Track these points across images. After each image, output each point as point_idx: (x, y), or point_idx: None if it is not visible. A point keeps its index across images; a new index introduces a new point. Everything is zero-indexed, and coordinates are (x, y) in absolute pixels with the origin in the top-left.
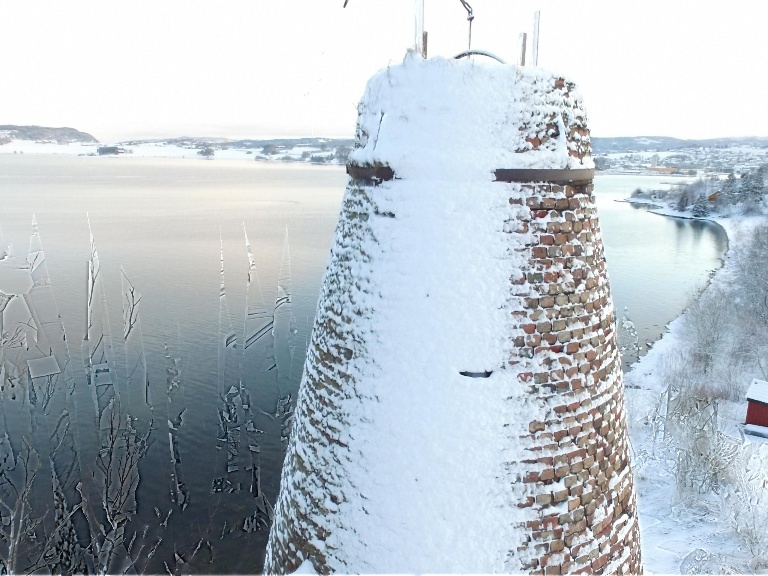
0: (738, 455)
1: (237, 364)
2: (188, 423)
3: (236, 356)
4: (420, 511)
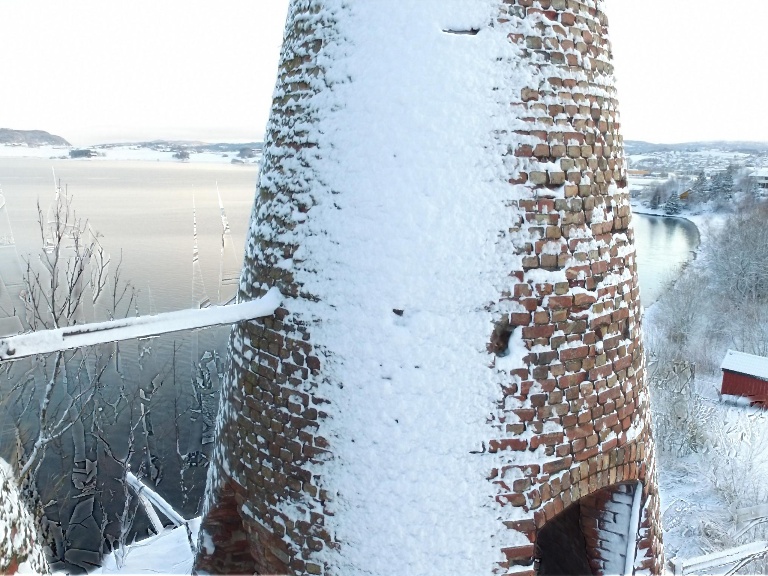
0: (716, 412)
1: (211, 331)
2: (160, 389)
3: None
4: (399, 189)
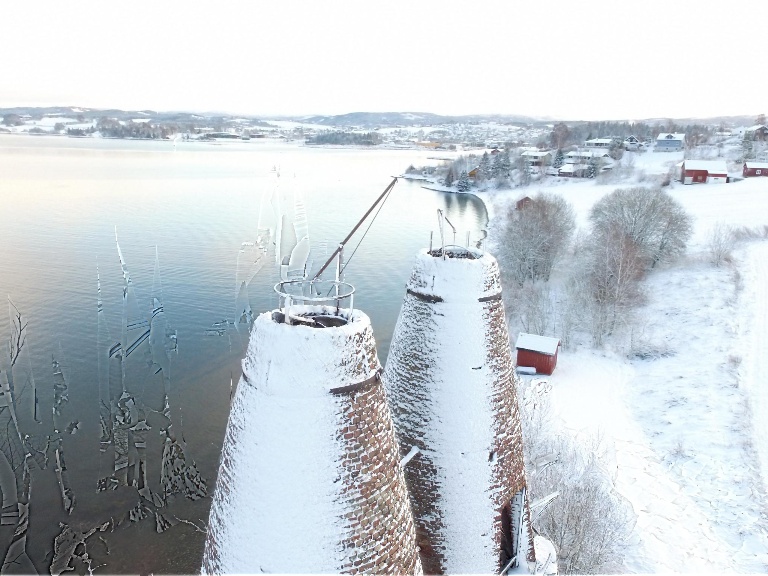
0: (517, 389)
1: (120, 372)
2: (84, 431)
3: (118, 365)
4: (462, 417)
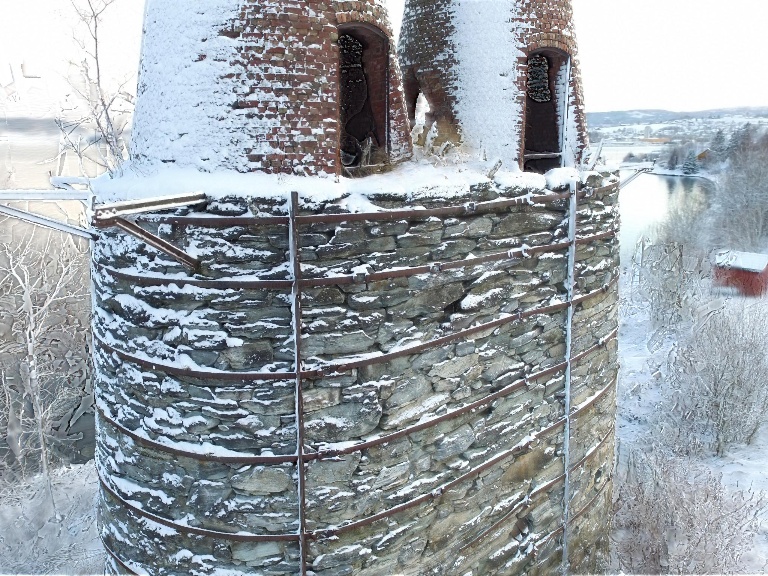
0: None
1: None
2: None
3: None
4: None
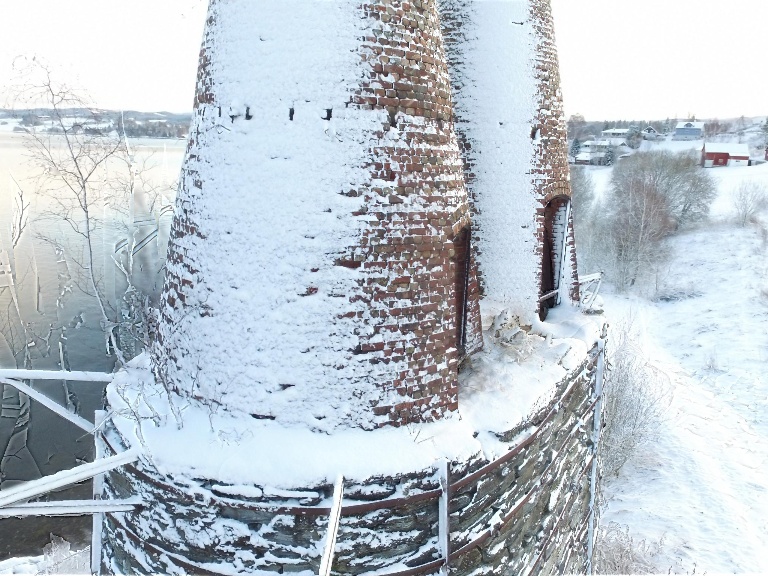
0: None
1: None
2: (88, 322)
3: (125, 262)
4: (501, 79)
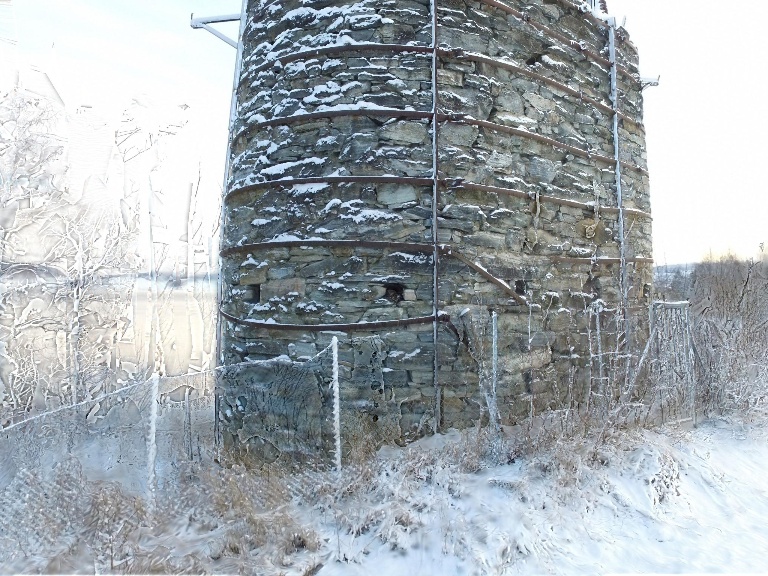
0: None
1: None
2: None
3: None
4: None
